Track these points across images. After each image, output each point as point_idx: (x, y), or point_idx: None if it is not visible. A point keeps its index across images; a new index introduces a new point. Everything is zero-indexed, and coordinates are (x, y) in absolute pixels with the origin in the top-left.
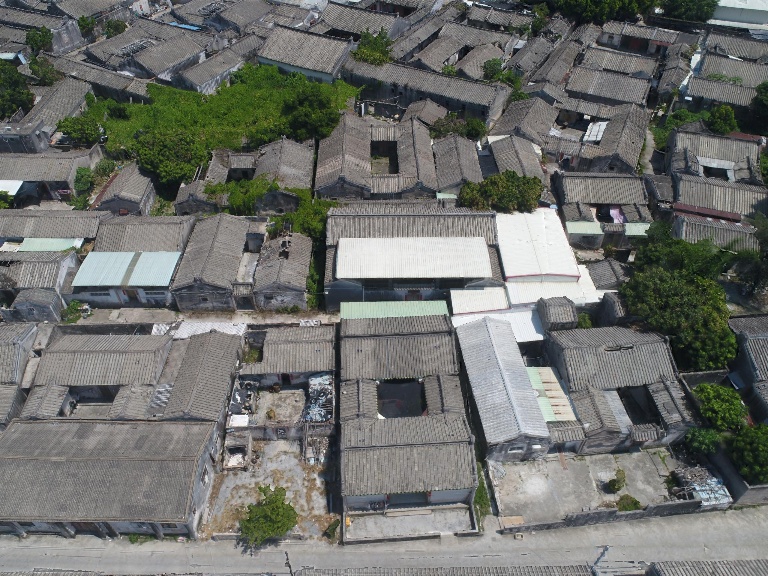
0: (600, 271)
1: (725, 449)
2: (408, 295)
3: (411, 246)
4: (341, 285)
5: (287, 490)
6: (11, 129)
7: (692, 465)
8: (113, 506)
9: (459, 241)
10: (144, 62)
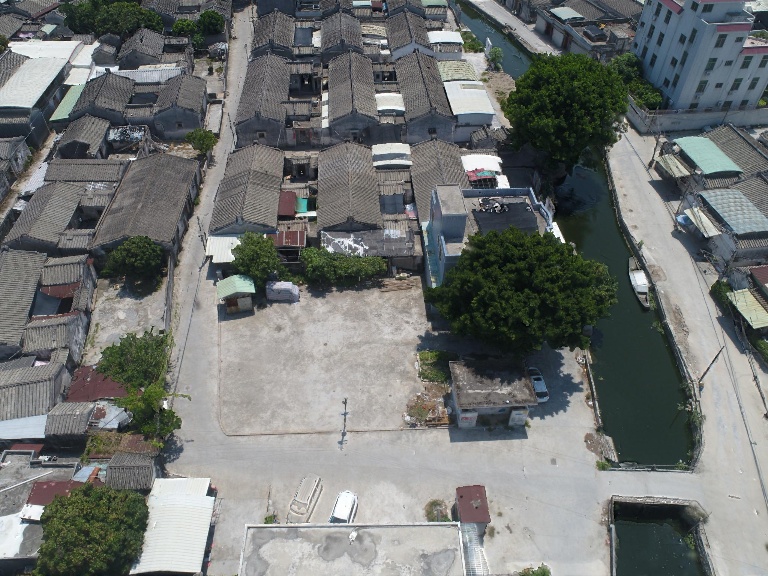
0: (79, 40)
1: (206, 32)
2: (54, 103)
3: (18, 81)
4: (33, 117)
5: (182, 156)
6: None
7: (206, 53)
8: (181, 185)
9: (25, 66)
10: None
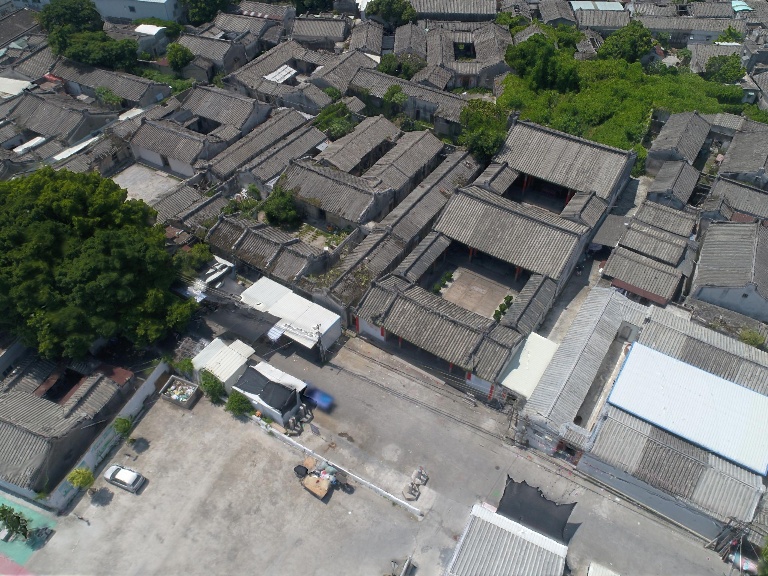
0: None
1: None
2: None
3: None
4: None
5: None
6: (764, 46)
7: None
8: None
9: None
10: (760, 134)
